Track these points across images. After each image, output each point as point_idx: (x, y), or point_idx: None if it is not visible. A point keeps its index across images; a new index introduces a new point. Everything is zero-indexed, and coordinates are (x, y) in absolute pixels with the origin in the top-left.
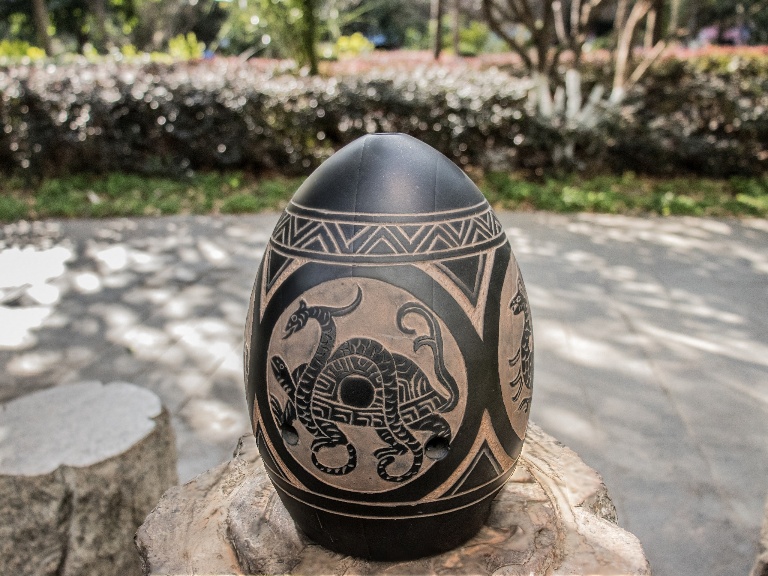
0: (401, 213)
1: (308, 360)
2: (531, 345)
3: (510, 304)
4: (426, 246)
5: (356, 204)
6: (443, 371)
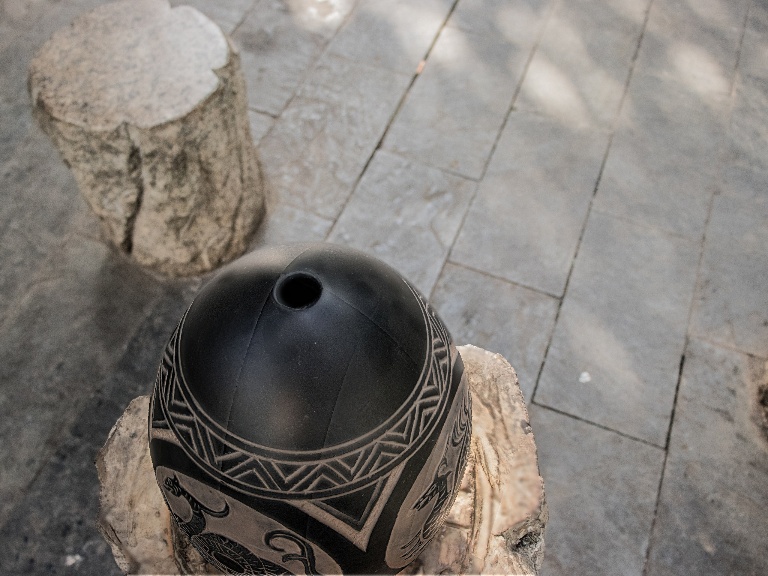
0: (279, 449)
1: (184, 520)
2: (449, 499)
3: (414, 506)
4: (305, 486)
5: (229, 421)
6: (315, 574)
